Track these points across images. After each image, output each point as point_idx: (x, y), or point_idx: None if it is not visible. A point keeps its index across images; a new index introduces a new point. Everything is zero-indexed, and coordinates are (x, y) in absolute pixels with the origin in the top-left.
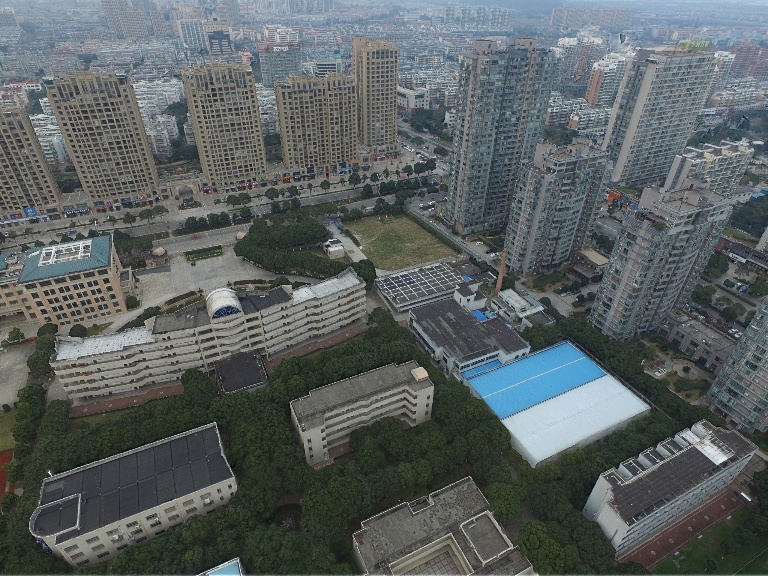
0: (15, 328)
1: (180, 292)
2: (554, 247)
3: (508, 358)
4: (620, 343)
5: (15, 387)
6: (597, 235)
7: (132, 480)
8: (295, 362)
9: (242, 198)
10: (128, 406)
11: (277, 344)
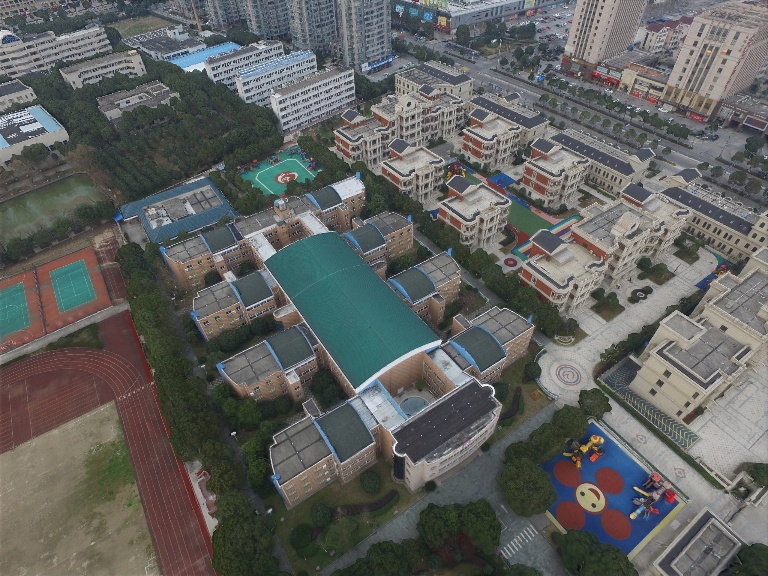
0: None
1: None
2: (236, 5)
3: (193, 51)
4: (251, 32)
5: None
6: None
7: None
8: (62, 62)
9: (17, 18)
10: None
11: None
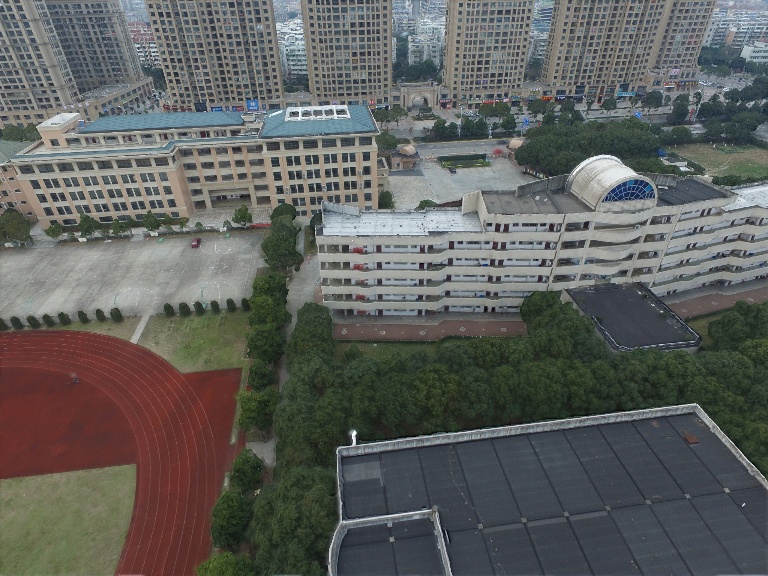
0: (244, 205)
1: (445, 199)
2: None
3: None
4: None
5: (241, 281)
6: None
7: (549, 507)
8: None
9: (501, 108)
10: (413, 339)
11: (663, 283)
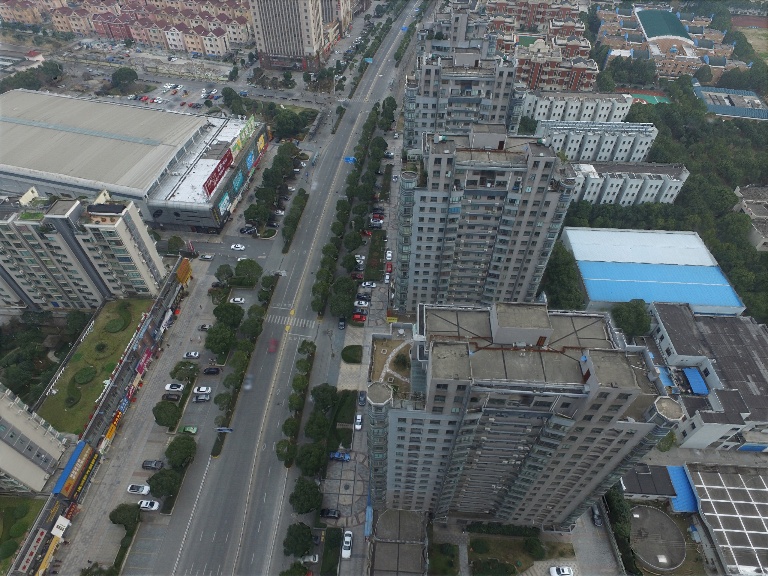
0: None
1: None
2: None
3: None
4: (555, 256)
5: None
6: (303, 480)
7: None
8: None
9: None
10: None
11: None
